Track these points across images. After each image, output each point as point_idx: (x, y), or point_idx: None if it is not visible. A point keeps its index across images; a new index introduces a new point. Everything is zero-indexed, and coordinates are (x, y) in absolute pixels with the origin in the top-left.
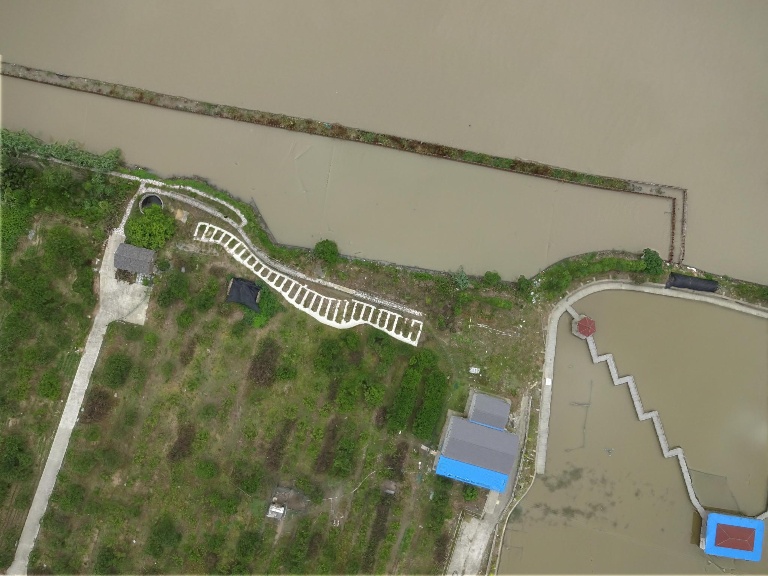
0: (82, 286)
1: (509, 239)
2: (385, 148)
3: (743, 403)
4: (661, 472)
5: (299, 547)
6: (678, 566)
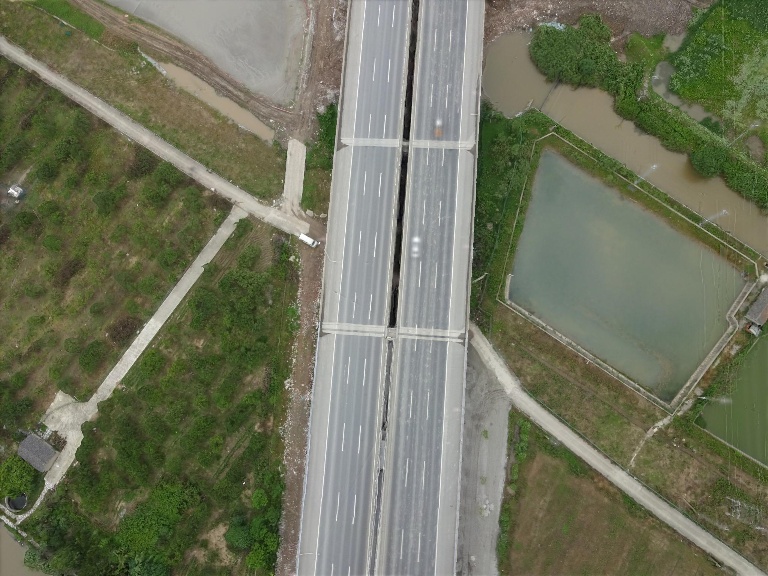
0: (84, 444)
1: None
2: None
3: None
4: None
5: (4, 157)
6: None
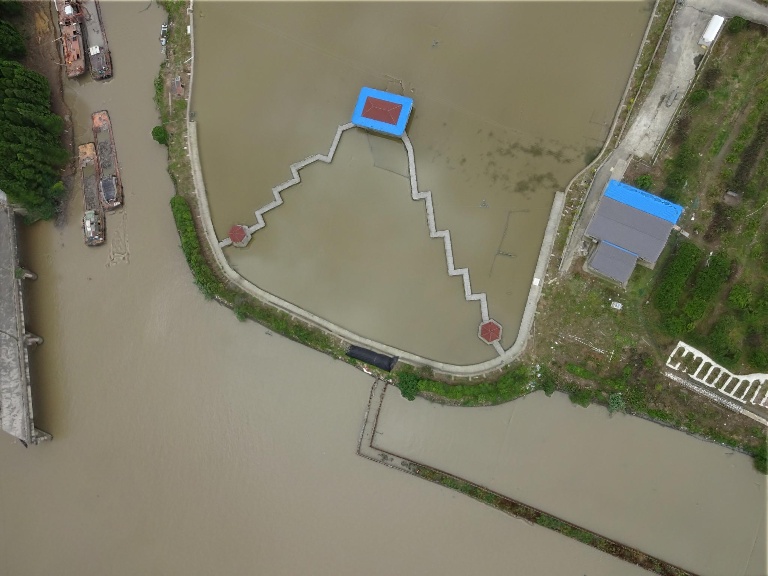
0: None
1: (551, 437)
2: (680, 567)
3: (343, 233)
4: (435, 178)
5: None
6: (441, 90)
